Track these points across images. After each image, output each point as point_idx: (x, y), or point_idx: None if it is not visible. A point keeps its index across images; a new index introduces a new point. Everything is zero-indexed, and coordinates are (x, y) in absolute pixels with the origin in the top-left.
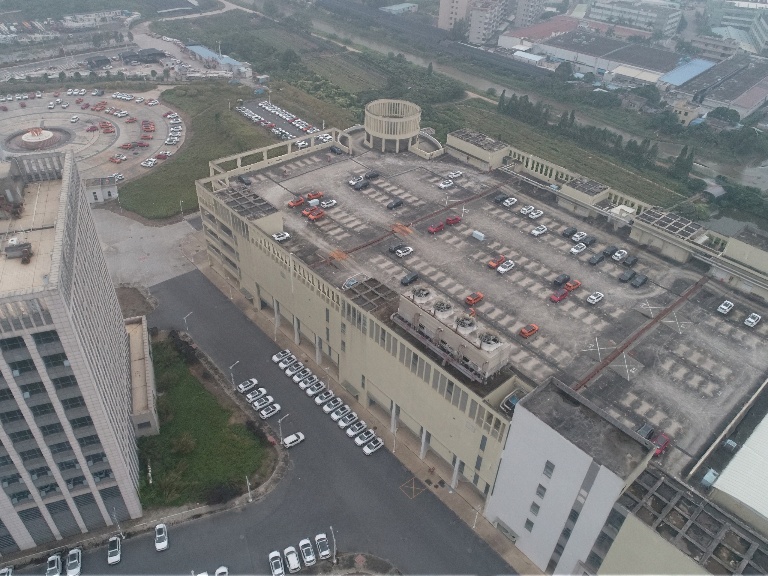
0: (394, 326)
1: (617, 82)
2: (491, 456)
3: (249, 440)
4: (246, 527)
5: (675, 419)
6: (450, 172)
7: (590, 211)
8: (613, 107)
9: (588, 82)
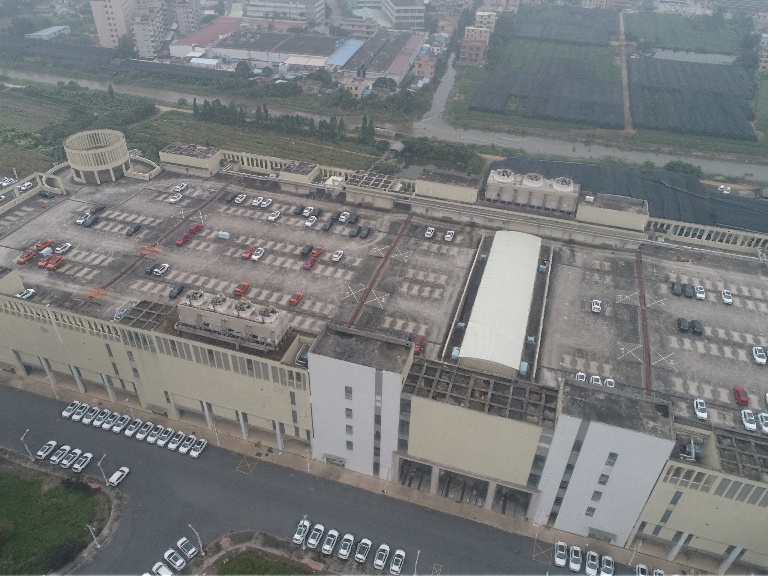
0: (181, 334)
1: (292, 71)
2: (302, 406)
3: (72, 497)
4: (105, 570)
5: (422, 323)
6: (175, 186)
7: (309, 188)
8: (297, 94)
9: (268, 76)
